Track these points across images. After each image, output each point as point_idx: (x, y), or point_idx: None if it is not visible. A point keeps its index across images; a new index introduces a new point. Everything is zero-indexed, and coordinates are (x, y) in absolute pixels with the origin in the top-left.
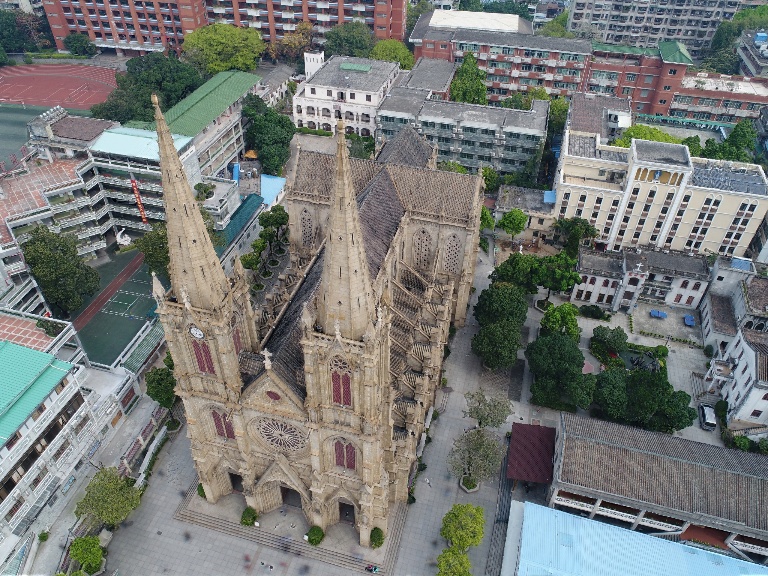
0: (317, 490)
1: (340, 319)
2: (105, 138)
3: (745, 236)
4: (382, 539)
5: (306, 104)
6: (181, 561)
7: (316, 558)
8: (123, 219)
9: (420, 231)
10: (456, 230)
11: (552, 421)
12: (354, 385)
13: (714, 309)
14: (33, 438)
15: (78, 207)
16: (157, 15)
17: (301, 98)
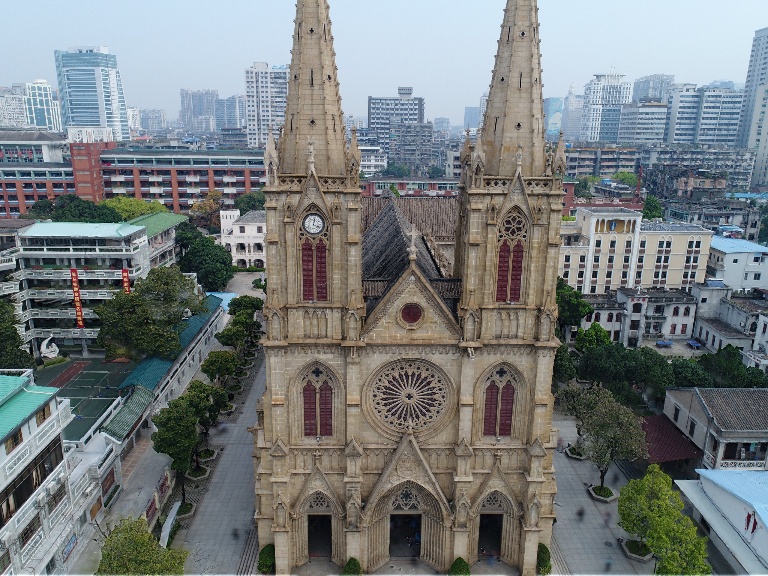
0: (465, 478)
1: None
2: (38, 227)
3: (699, 273)
4: None
5: (236, 241)
6: None
7: None
8: (49, 327)
9: None
10: None
11: None
12: (532, 253)
13: None
14: (2, 484)
15: (2, 294)
16: (49, 196)
17: (231, 236)
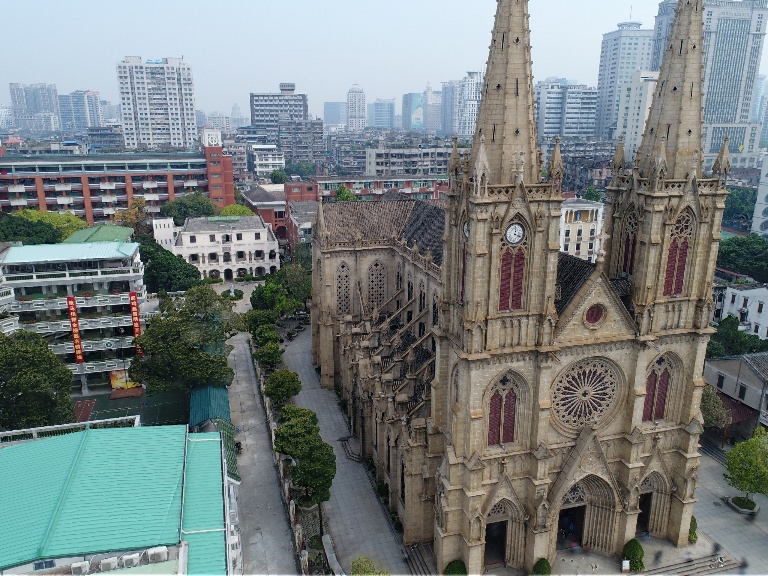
0: (637, 464)
1: (688, 155)
2: (18, 251)
3: None
4: None
5: (189, 252)
6: None
7: None
8: None
9: None
10: None
11: None
12: (698, 249)
13: None
14: None
15: None
16: None
17: (182, 246)
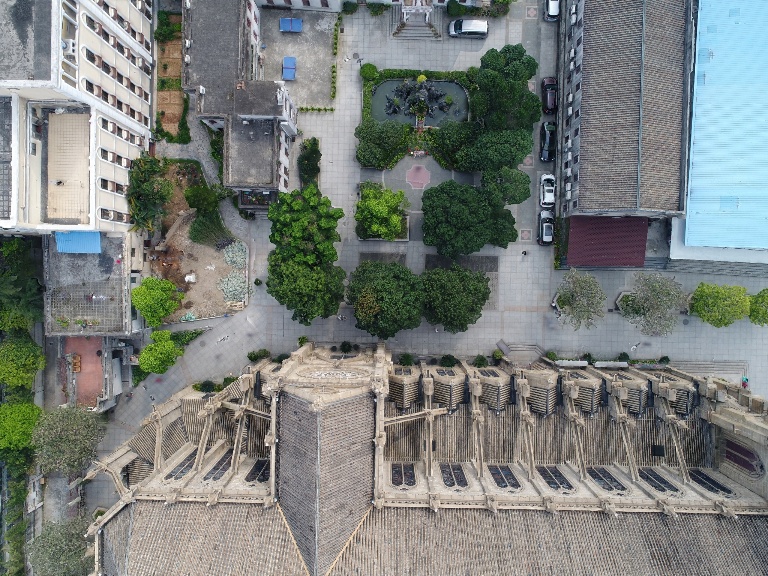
0: None
1: None
2: None
3: None
4: None
5: None
6: None
7: None
8: None
9: None
10: None
11: (519, 216)
12: None
13: None
14: None
15: None
16: None
17: None
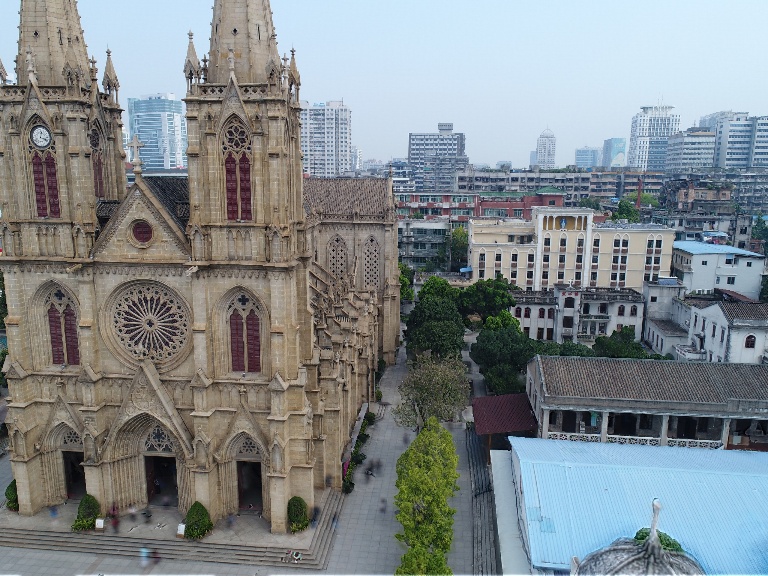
0: (202, 413)
1: (235, 57)
2: None
3: None
4: (307, 520)
5: None
6: None
7: (197, 558)
8: None
9: (334, 240)
10: (373, 231)
11: None
12: (255, 165)
13: (659, 325)
14: None
15: None
16: None
17: None
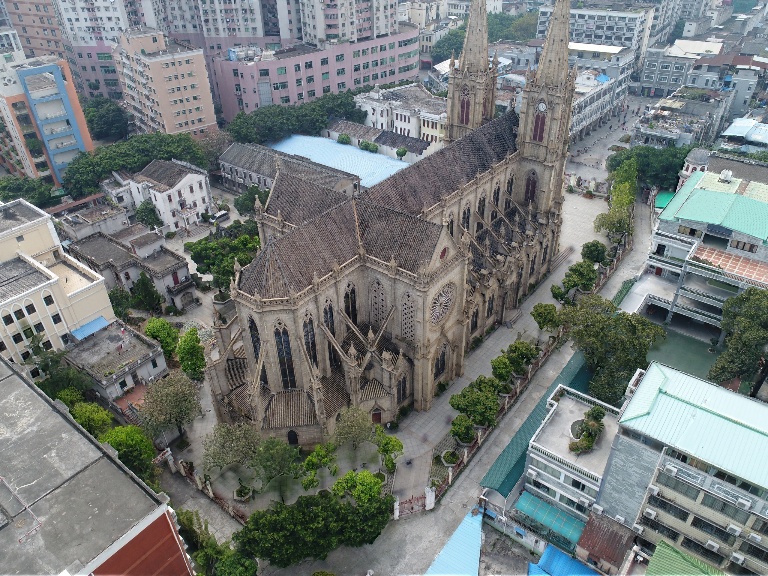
0: None
1: None
2: None
3: None
4: None
5: None
6: (566, 235)
7: None
8: None
9: None
10: None
11: None
12: None
13: None
14: None
15: None
16: None
17: None
